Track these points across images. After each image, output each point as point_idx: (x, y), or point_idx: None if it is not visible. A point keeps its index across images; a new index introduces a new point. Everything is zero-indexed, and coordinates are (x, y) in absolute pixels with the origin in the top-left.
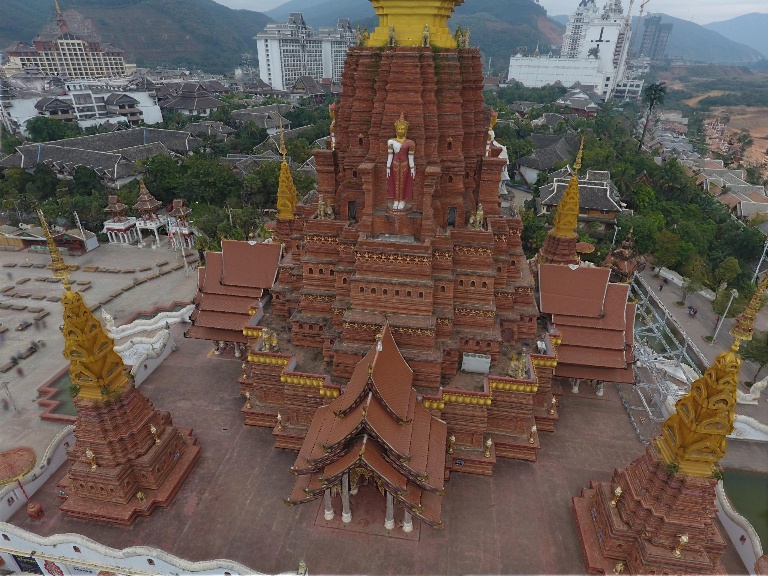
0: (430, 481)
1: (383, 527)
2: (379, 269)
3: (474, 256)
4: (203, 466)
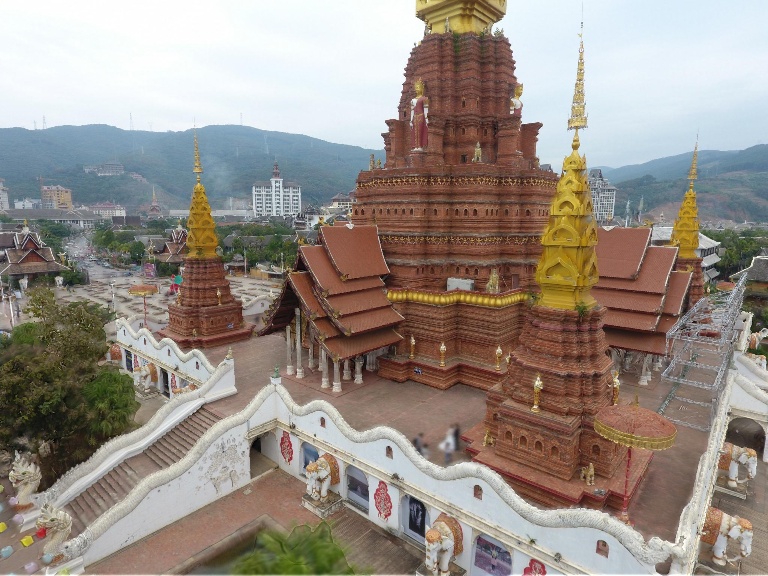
0: (345, 324)
1: (320, 386)
2: (385, 192)
3: (468, 186)
4: (245, 342)
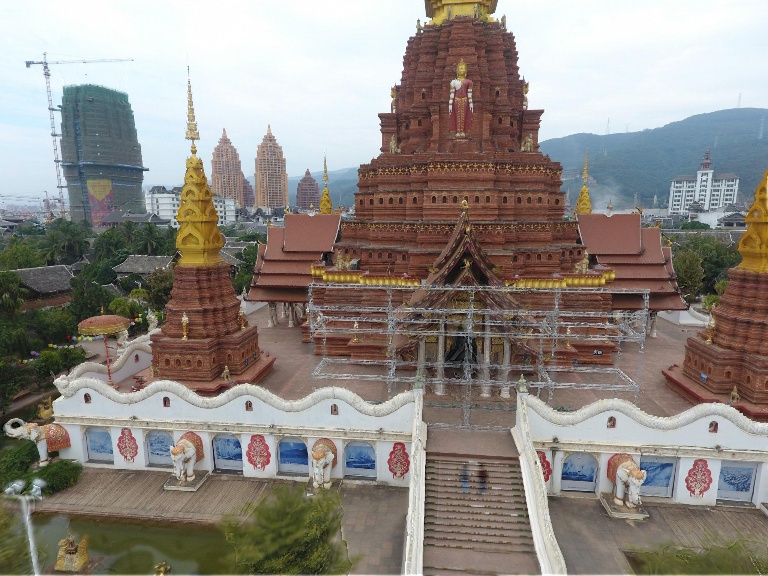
0: (262, 279)
1: None
2: None
3: None
4: None
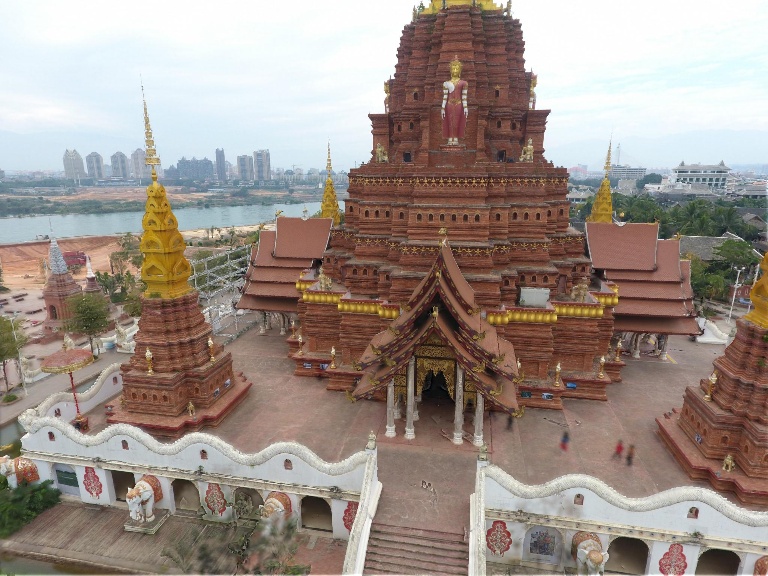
0: None
1: None
2: None
3: None
4: None
